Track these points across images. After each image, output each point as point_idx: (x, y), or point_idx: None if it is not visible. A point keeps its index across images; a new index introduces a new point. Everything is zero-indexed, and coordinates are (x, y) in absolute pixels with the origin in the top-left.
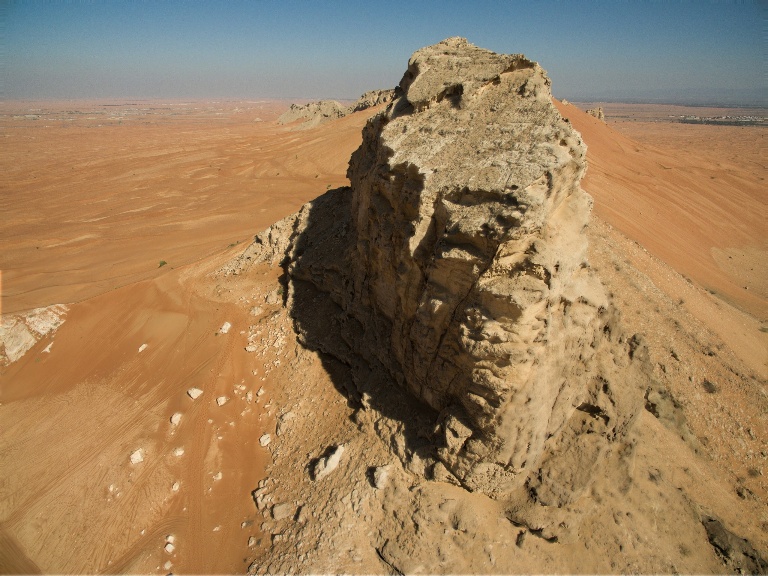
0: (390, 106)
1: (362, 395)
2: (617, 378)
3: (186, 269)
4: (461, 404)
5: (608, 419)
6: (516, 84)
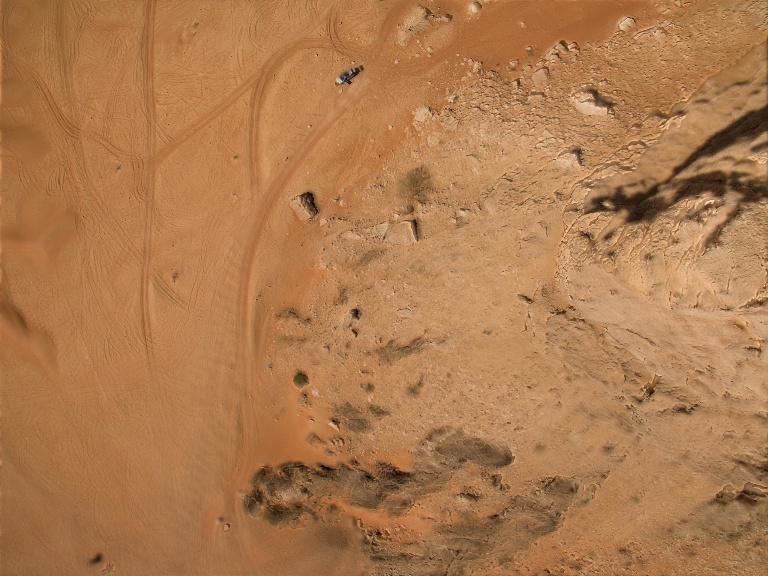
0: None
1: None
2: (701, 426)
3: None
4: None
5: (640, 399)
6: None
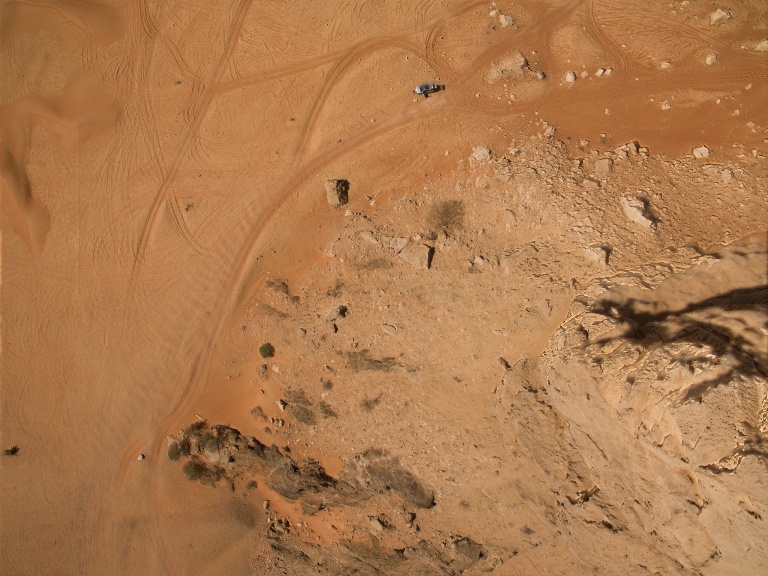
0: None
1: None
2: (618, 550)
3: None
4: None
5: (572, 502)
6: None
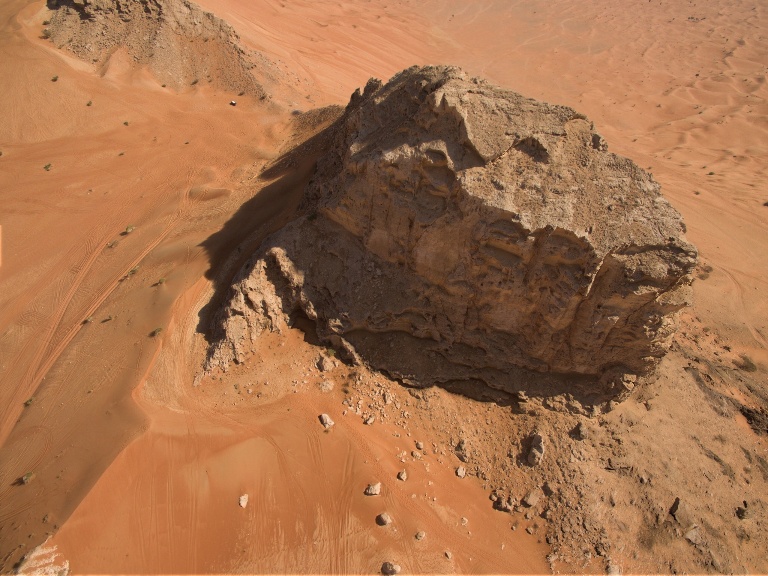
0: (428, 150)
1: (518, 394)
2: None
3: (143, 392)
4: (622, 364)
5: None
6: (586, 138)
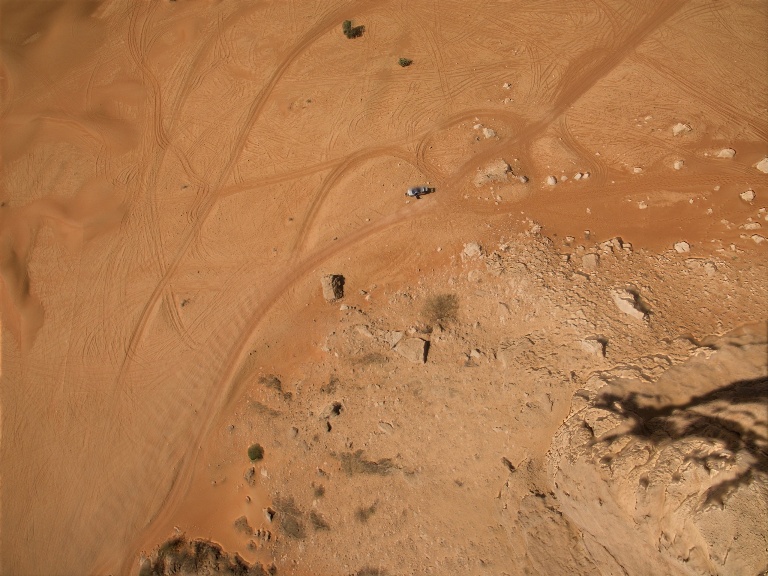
0: None
1: None
2: None
3: None
4: None
5: None
6: None
